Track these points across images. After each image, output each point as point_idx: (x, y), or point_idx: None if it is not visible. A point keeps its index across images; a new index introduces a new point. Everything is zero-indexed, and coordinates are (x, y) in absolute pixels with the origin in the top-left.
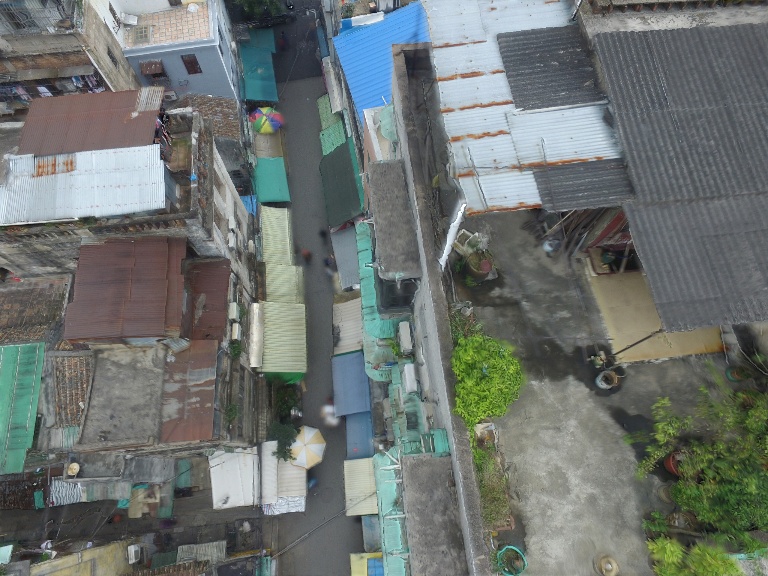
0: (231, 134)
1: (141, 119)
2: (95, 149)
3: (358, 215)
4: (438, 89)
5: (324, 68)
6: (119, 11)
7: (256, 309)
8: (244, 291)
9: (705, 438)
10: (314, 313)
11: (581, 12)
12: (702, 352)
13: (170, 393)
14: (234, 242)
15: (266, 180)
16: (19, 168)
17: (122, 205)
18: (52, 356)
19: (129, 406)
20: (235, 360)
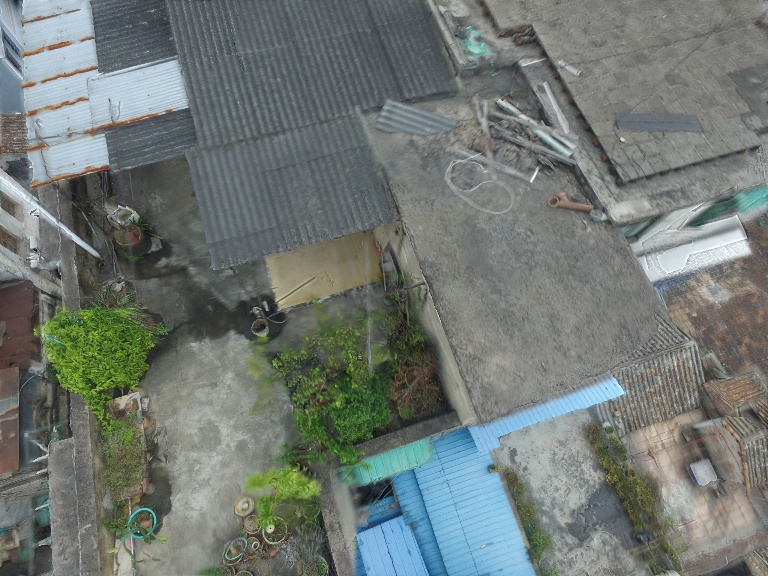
0: None
1: None
2: None
3: None
4: None
5: None
6: None
7: None
8: None
9: None
10: None
11: None
12: (362, 284)
13: None
14: None
15: None
16: None
17: None
18: None
19: None
20: None
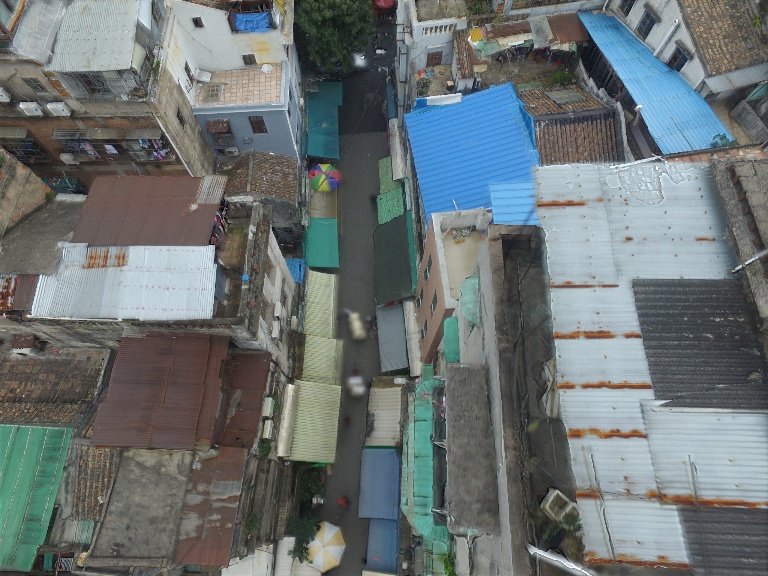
0: (288, 196)
1: (200, 213)
2: (149, 244)
3: (408, 297)
4: (535, 275)
5: (390, 130)
6: (194, 67)
7: (291, 391)
8: (281, 375)
9: None
10: (349, 388)
11: (748, 272)
12: None
13: (191, 506)
14: (278, 332)
15: (317, 242)
16: (71, 257)
17: (168, 310)
18: (78, 444)
19: (147, 517)
20: (263, 459)
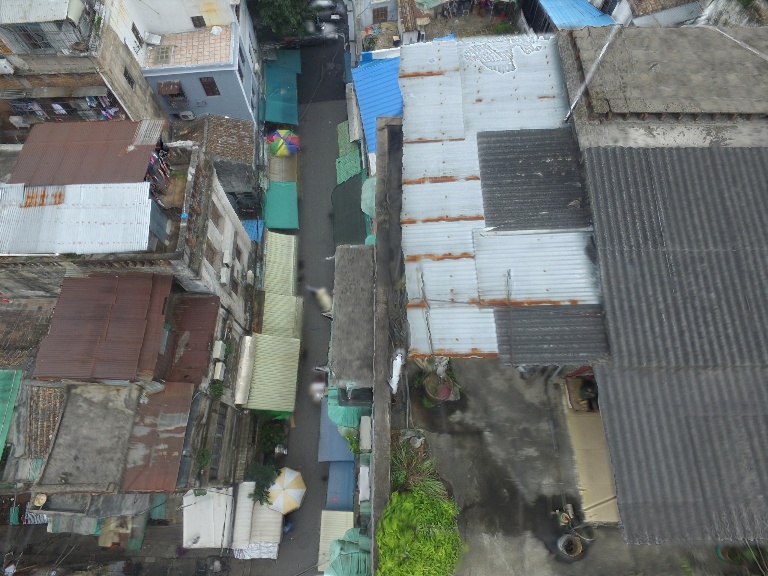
0: (244, 158)
1: (136, 153)
2: (85, 183)
3: None
4: None
5: (347, 94)
6: (143, 30)
7: (248, 342)
8: (236, 325)
9: None
10: (312, 345)
11: (575, 116)
12: None
13: (138, 437)
14: (226, 278)
15: (276, 205)
16: (8, 197)
17: (104, 243)
18: (28, 385)
19: (95, 448)
20: (215, 400)
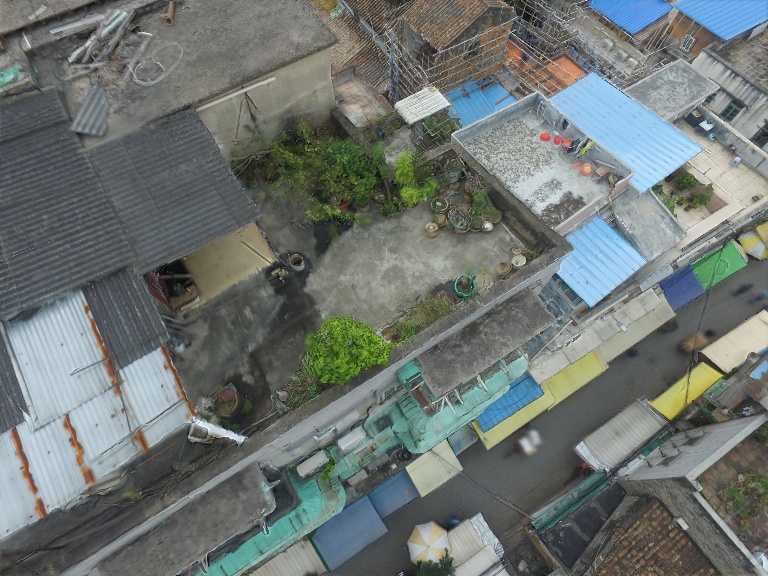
0: None
1: None
2: None
3: None
4: None
5: None
6: None
7: None
8: None
9: (319, 187)
10: None
11: None
12: None
13: None
14: None
15: None
16: None
17: None
18: None
19: None
20: None
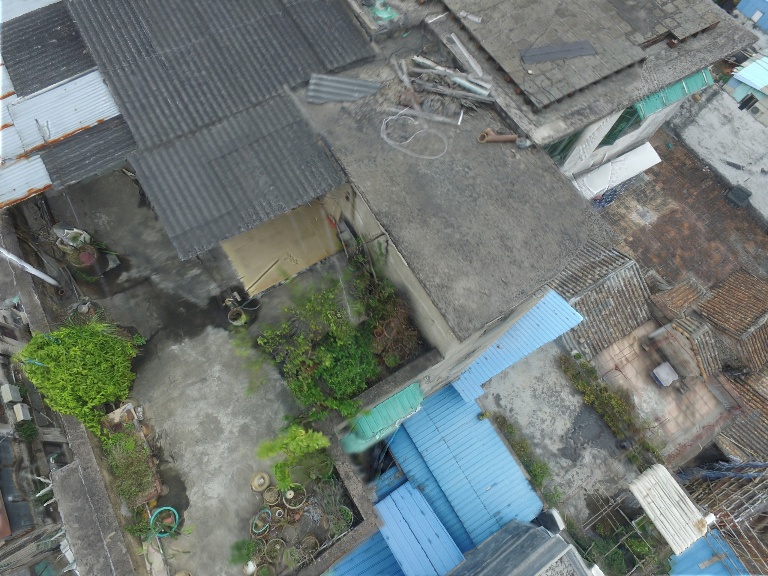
0: None
1: None
2: None
3: None
4: None
5: None
6: None
7: None
8: None
9: None
10: None
11: None
12: (325, 257)
13: None
14: None
15: None
16: None
17: None
18: None
19: None
20: (33, 441)
